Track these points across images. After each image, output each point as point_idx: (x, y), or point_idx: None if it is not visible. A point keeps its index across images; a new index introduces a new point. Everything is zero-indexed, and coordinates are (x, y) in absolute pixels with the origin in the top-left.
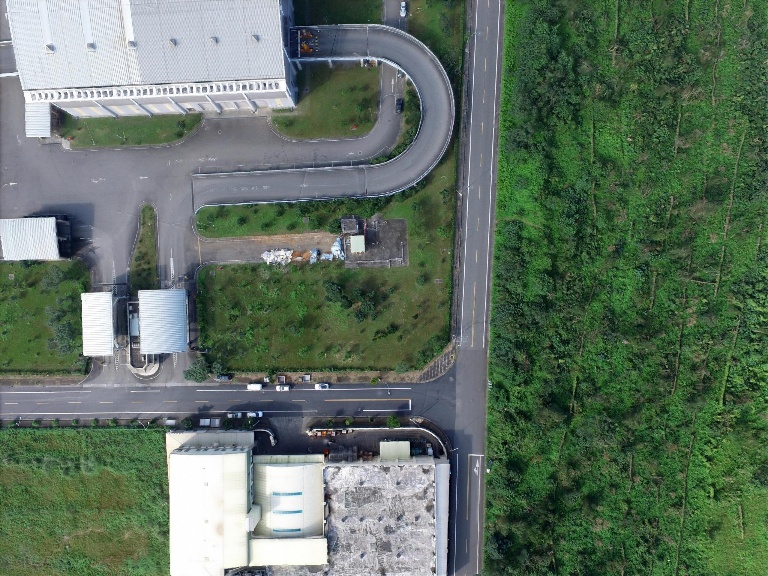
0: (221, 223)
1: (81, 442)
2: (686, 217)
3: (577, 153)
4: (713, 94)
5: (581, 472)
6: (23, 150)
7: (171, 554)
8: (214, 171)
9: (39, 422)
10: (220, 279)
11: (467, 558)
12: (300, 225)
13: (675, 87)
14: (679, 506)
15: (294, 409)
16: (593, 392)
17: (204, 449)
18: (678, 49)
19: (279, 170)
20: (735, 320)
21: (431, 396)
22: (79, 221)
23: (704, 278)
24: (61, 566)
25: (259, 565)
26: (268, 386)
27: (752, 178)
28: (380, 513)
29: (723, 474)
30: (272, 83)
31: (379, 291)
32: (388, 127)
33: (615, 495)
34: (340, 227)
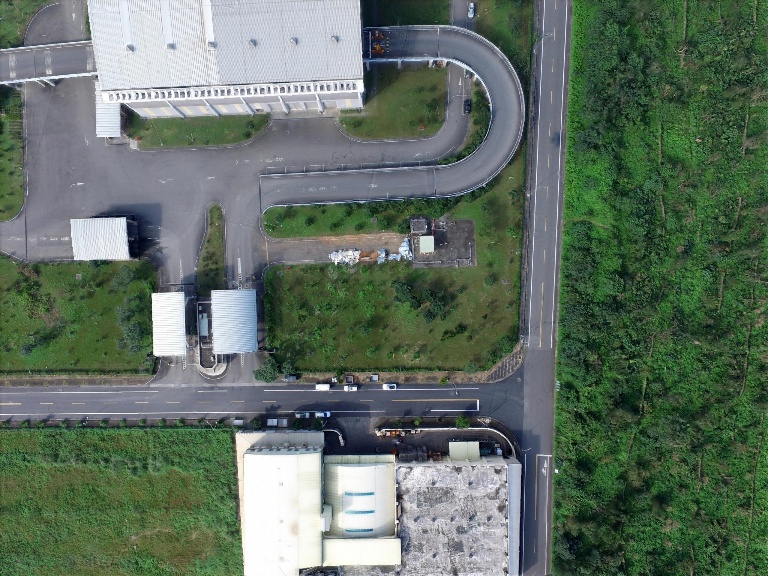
0: (289, 223)
1: (148, 442)
2: (753, 218)
3: (645, 154)
4: None
5: (650, 472)
6: (91, 150)
7: (245, 554)
8: (282, 171)
9: (106, 422)
10: (288, 279)
11: (535, 558)
12: (368, 225)
13: None
14: (747, 507)
15: (362, 409)
16: (663, 392)
17: (277, 449)
18: (747, 50)
19: (347, 170)
20: None
21: (499, 396)
22: (146, 221)
23: None
24: (129, 566)
25: (332, 565)
26: (336, 386)
27: None
28: (452, 513)
29: None
30: (349, 84)
31: (447, 291)
32: (456, 128)
33: (684, 495)
34: (409, 227)
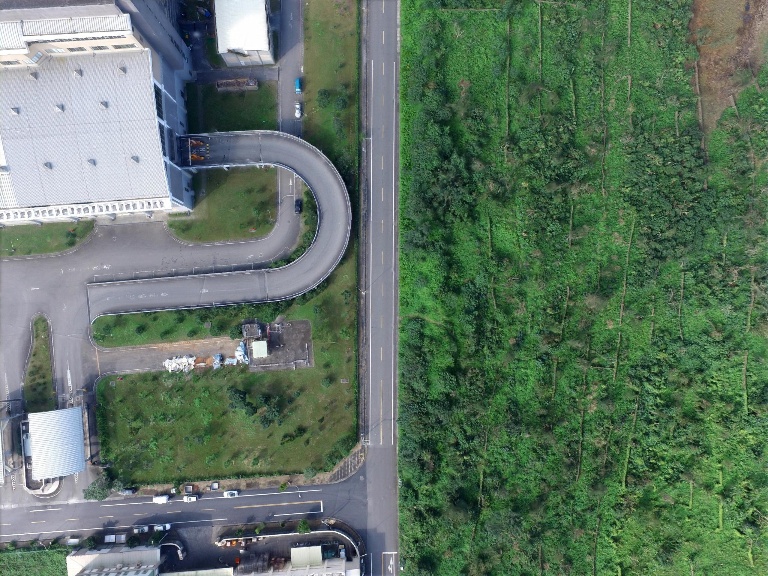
0: (119, 332)
1: None
2: (583, 305)
3: (476, 247)
4: (603, 186)
5: (492, 563)
6: None
7: None
8: (110, 279)
9: None
10: (120, 390)
11: None
12: (202, 331)
13: (565, 182)
14: None
15: (203, 519)
16: (499, 485)
17: (105, 574)
18: (566, 146)
19: (177, 277)
20: (633, 403)
21: (342, 496)
22: None
23: (603, 363)
24: None
25: None
26: (175, 497)
27: (643, 265)
28: None
29: (629, 553)
30: (157, 202)
31: (285, 394)
32: (288, 228)
33: None
34: (241, 333)
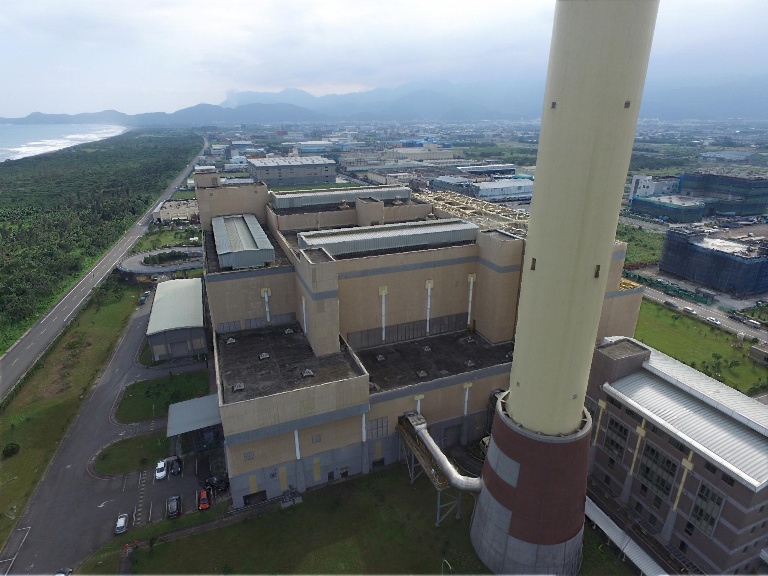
0: None
1: None
2: None
3: None
4: None
5: None
6: None
7: None
8: None
9: None
10: None
11: None
12: None
13: None
14: None
15: None
16: None
17: None
18: None
19: None
20: None
21: None
22: None
23: None
24: None
25: None
26: None
27: None
28: None
29: None
30: None
31: None
32: None
33: None
34: None
